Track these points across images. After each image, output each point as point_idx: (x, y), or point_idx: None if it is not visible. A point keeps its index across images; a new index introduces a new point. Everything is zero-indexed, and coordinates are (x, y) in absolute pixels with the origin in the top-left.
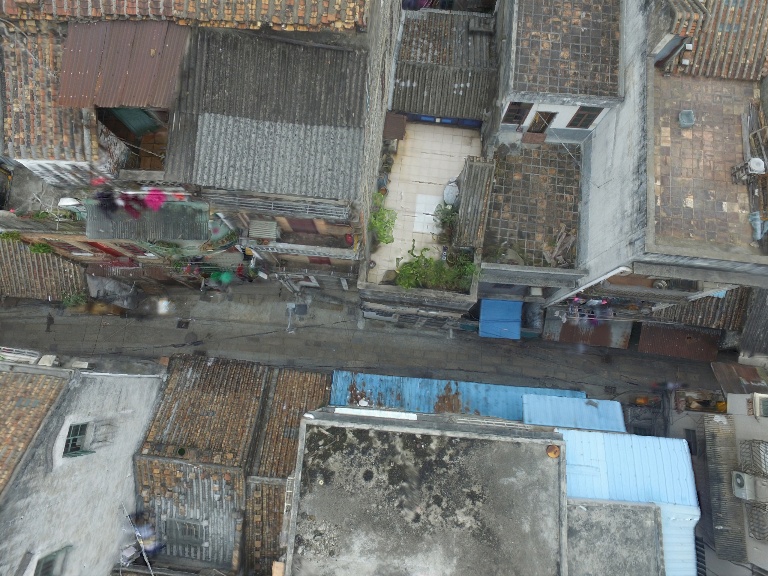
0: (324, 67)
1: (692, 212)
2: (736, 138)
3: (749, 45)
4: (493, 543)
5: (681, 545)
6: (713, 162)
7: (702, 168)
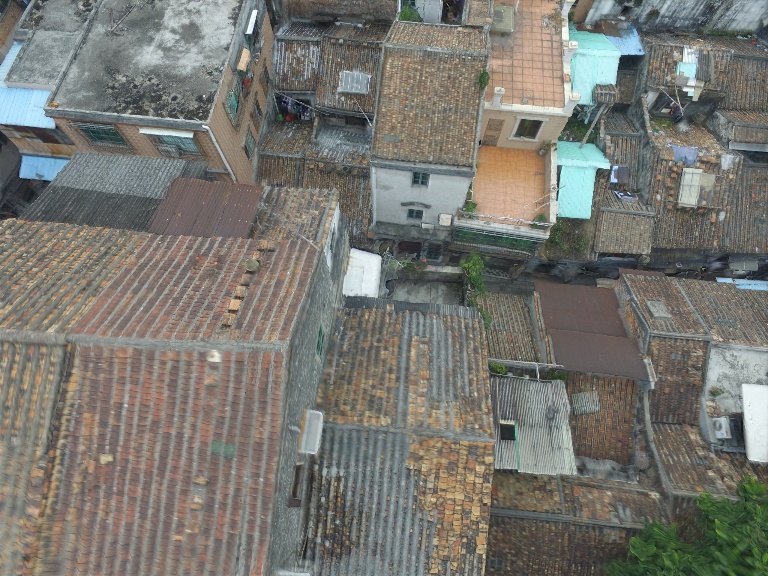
0: (58, 220)
1: None
2: None
3: None
4: (109, 68)
5: (4, 72)
6: None
7: None
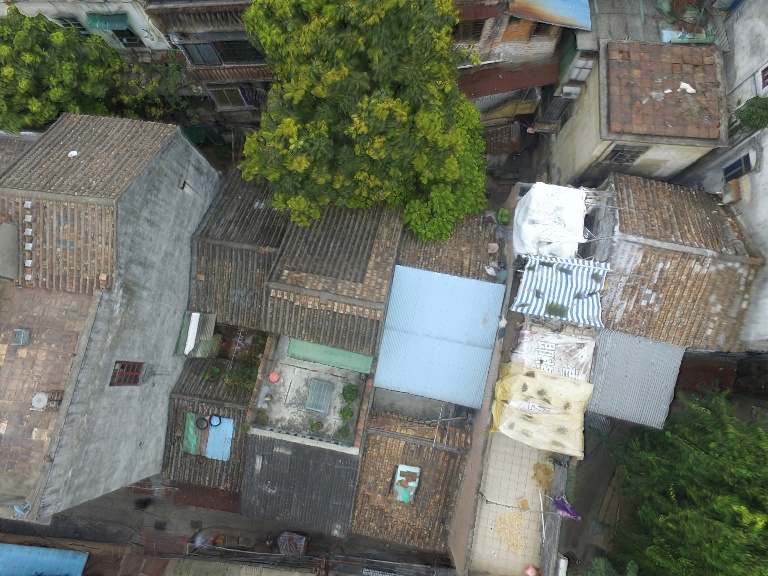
0: None
1: (1, 439)
2: (68, 357)
3: (87, 262)
4: None
5: None
6: (38, 384)
7: (25, 390)
